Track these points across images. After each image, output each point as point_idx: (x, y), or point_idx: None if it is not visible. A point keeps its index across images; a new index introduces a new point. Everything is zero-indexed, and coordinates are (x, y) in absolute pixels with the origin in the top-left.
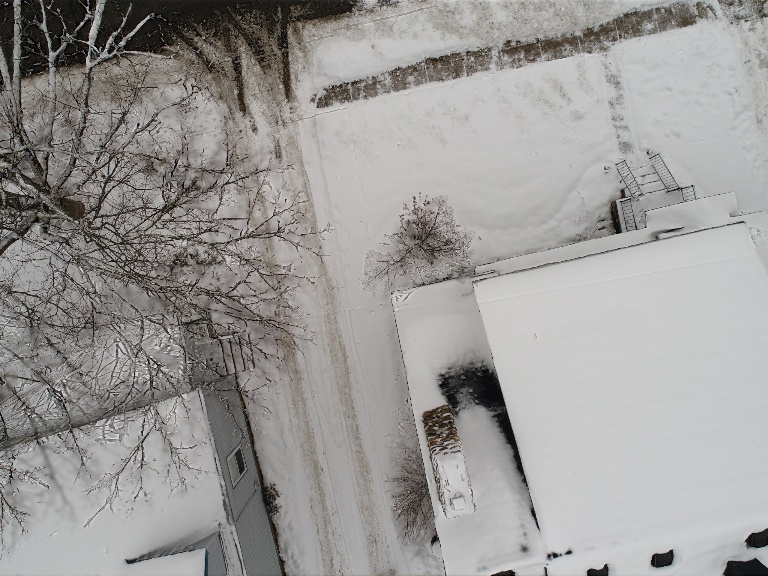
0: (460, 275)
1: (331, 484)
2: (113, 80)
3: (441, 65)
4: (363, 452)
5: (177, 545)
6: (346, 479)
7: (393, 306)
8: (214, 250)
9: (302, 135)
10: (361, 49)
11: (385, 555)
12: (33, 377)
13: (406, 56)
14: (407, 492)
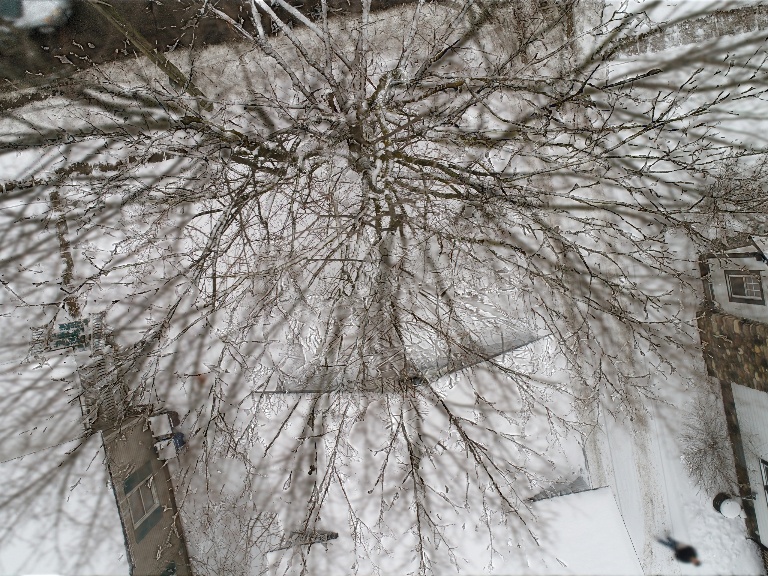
0: (755, 230)
1: (608, 443)
2: (393, 30)
3: (732, 19)
4: (642, 410)
5: (563, 486)
6: (625, 437)
7: (761, 249)
8: (501, 202)
9: (588, 88)
10: (654, 1)
11: (660, 515)
12: (318, 328)
13: (700, 8)
14: (693, 450)
